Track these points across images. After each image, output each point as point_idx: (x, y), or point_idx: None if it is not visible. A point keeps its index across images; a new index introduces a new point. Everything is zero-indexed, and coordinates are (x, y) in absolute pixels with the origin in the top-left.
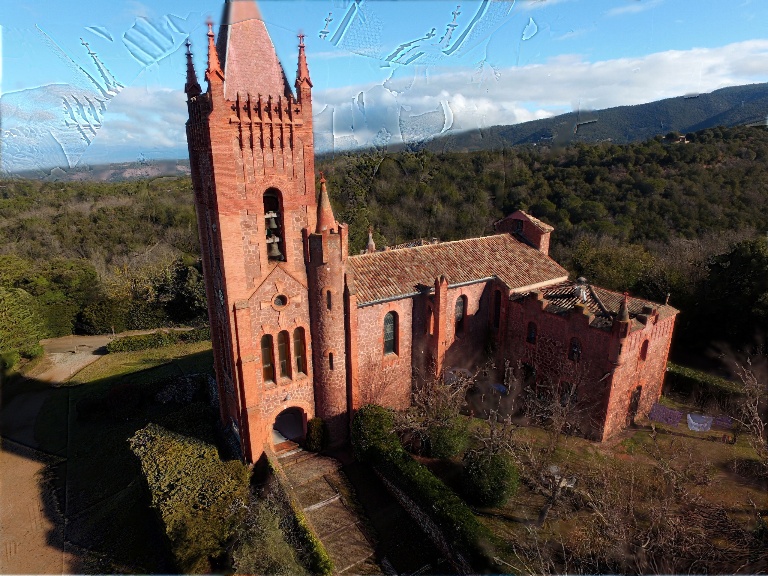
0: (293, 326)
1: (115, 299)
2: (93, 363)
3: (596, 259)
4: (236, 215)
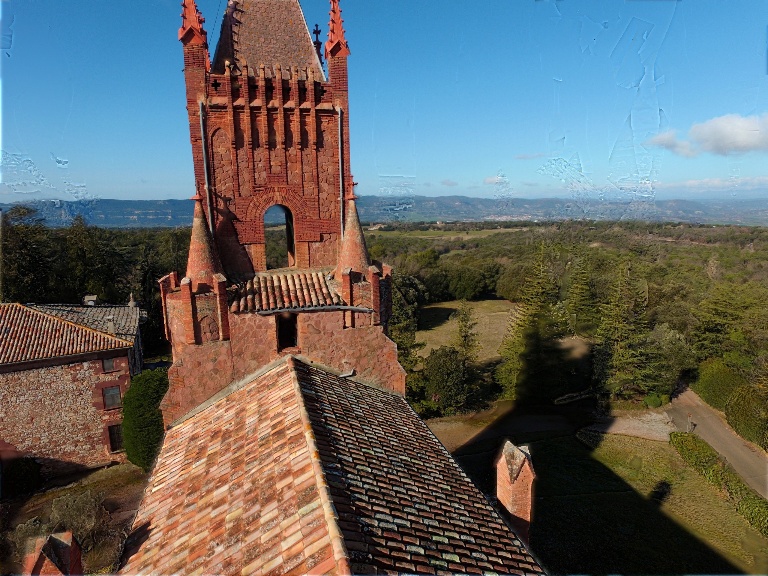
0: None
1: (759, 391)
2: (639, 438)
3: None
4: None
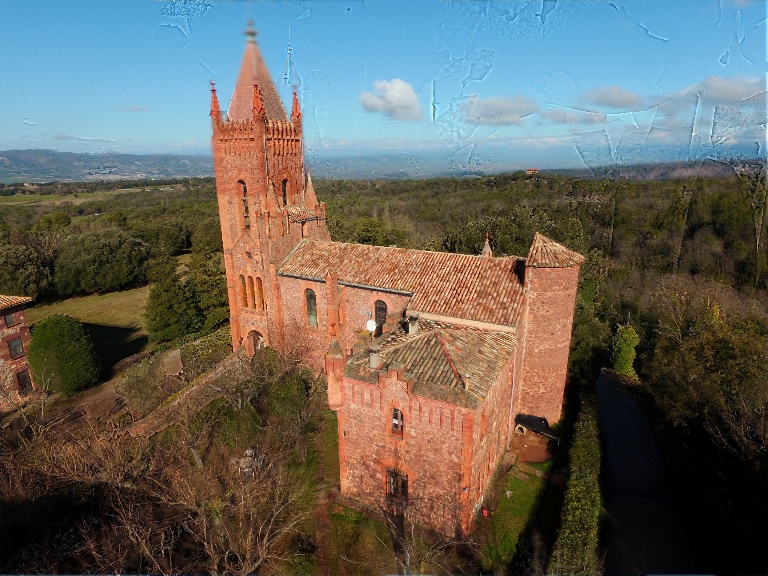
0: (255, 275)
1: None
2: None
3: (707, 346)
4: (225, 195)
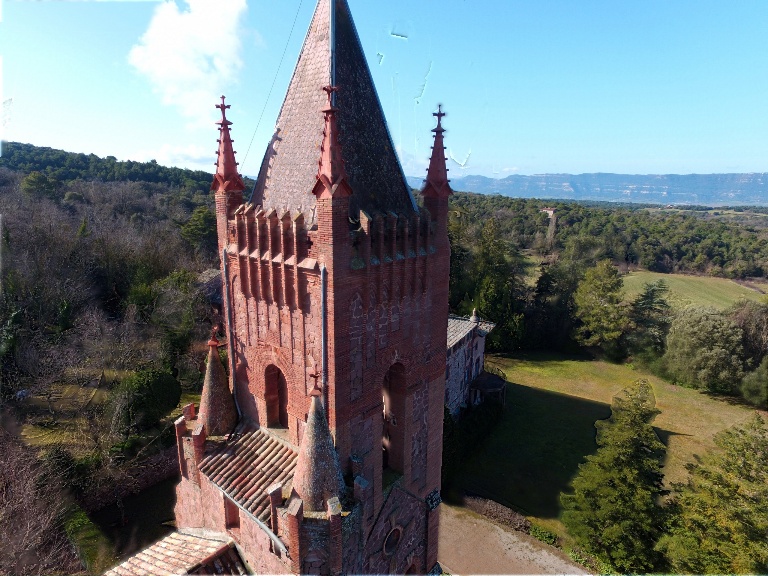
0: None
1: None
2: None
3: None
4: None
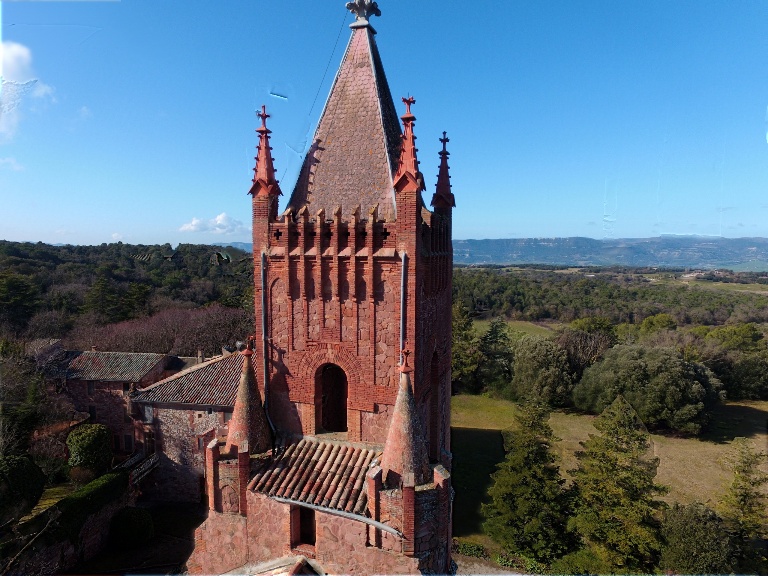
0: None
1: None
2: None
3: None
4: None
